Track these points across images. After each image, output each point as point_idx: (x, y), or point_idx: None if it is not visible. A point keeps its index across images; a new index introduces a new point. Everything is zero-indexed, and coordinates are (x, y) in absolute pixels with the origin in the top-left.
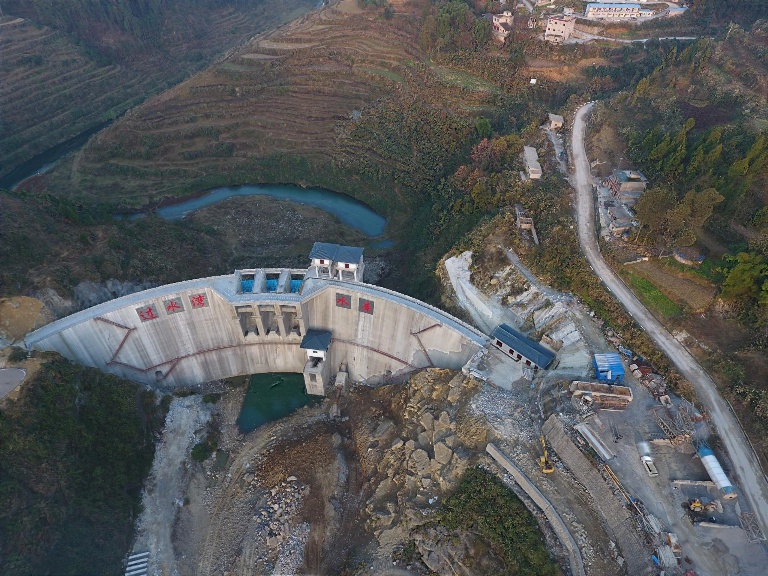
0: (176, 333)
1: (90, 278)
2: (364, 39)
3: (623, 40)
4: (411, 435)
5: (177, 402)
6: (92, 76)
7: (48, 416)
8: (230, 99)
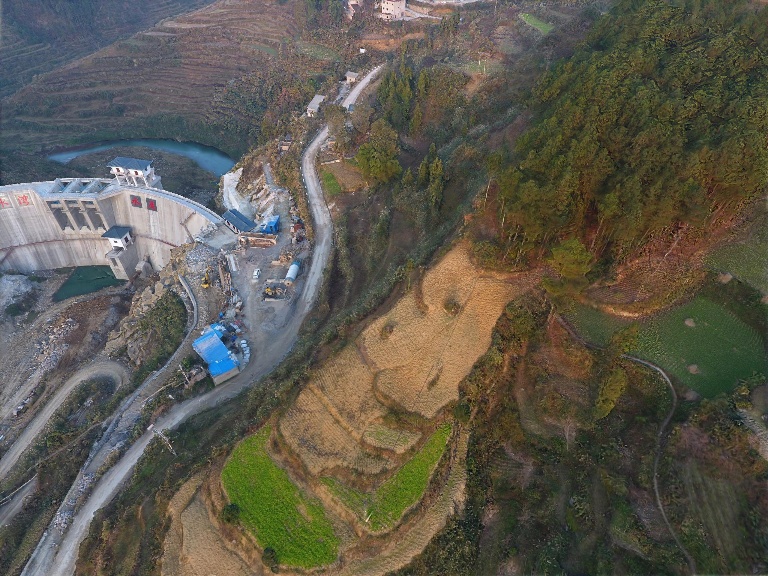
0: (8, 226)
1: None
2: (258, 21)
3: None
4: None
5: (5, 278)
6: (21, 52)
7: None
8: (128, 69)
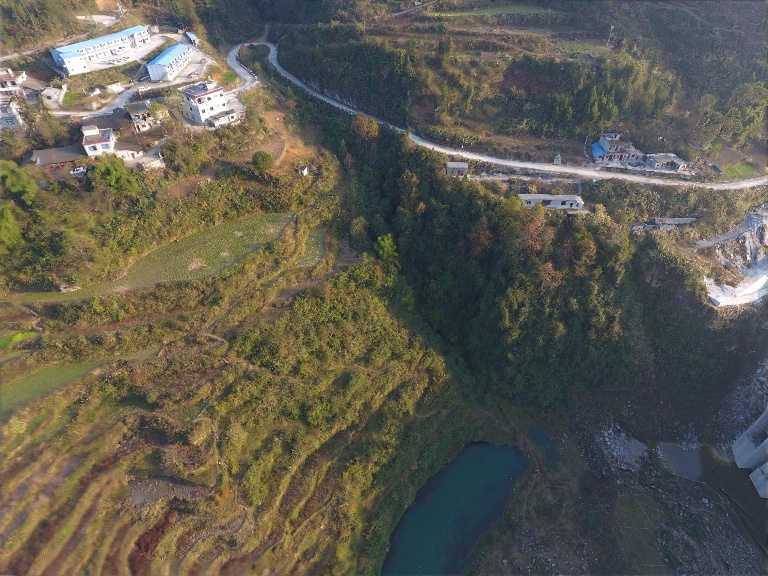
0: None
1: None
2: None
3: (249, 84)
4: None
5: None
6: None
7: None
8: None
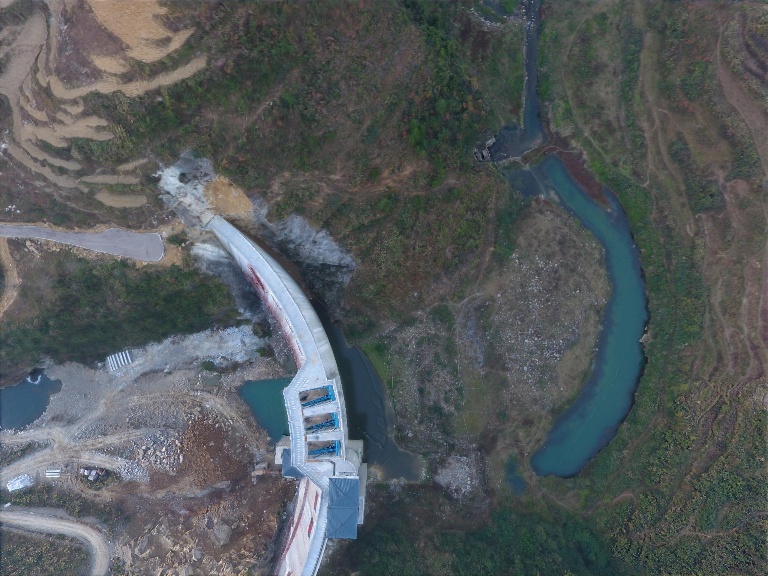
0: None
1: (310, 222)
2: None
3: None
4: (200, 568)
5: (247, 330)
6: None
7: (148, 286)
8: None
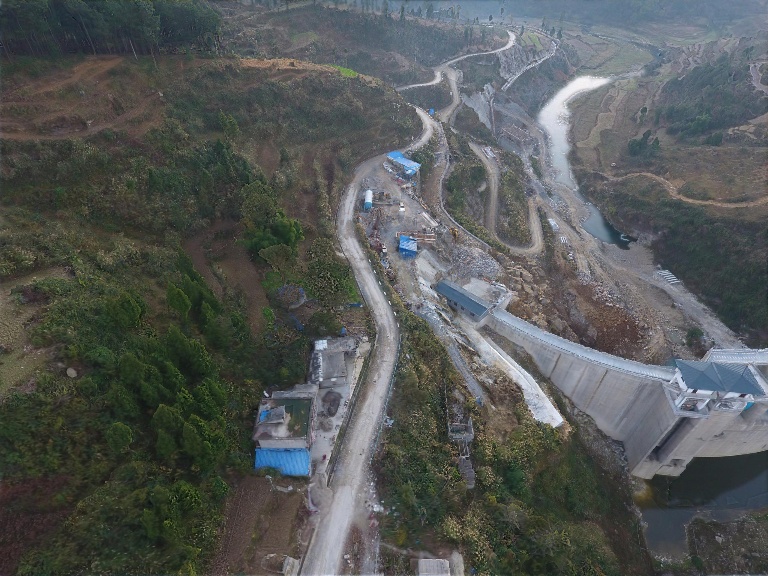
0: None
1: None
2: None
3: None
4: None
5: None
6: None
7: None
8: None
